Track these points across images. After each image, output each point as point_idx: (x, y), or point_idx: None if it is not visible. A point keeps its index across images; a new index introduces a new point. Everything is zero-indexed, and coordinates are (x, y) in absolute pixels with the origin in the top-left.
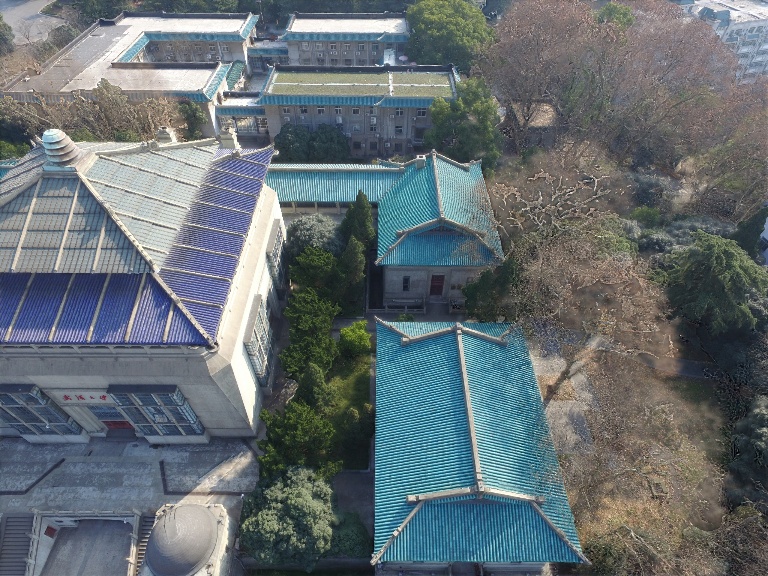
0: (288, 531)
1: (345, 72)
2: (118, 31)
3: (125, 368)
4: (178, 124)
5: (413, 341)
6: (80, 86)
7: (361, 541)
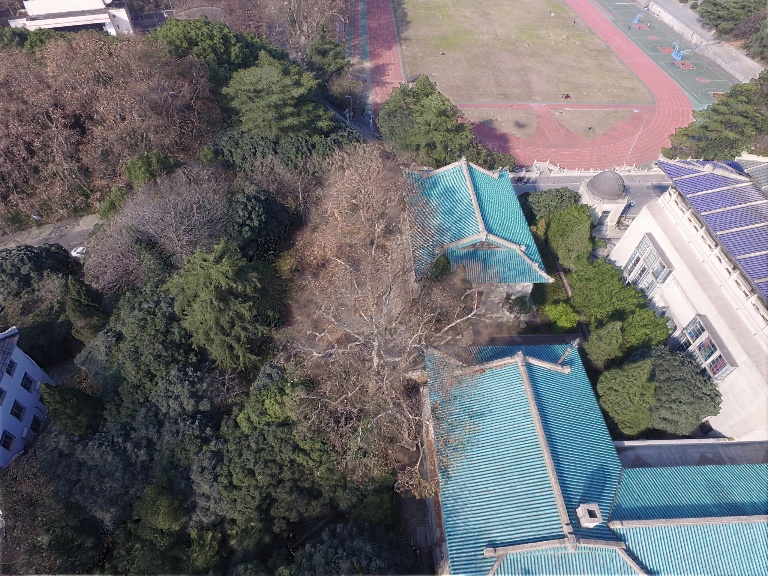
0: None
1: None
2: None
3: None
4: None
5: None
6: None
7: None
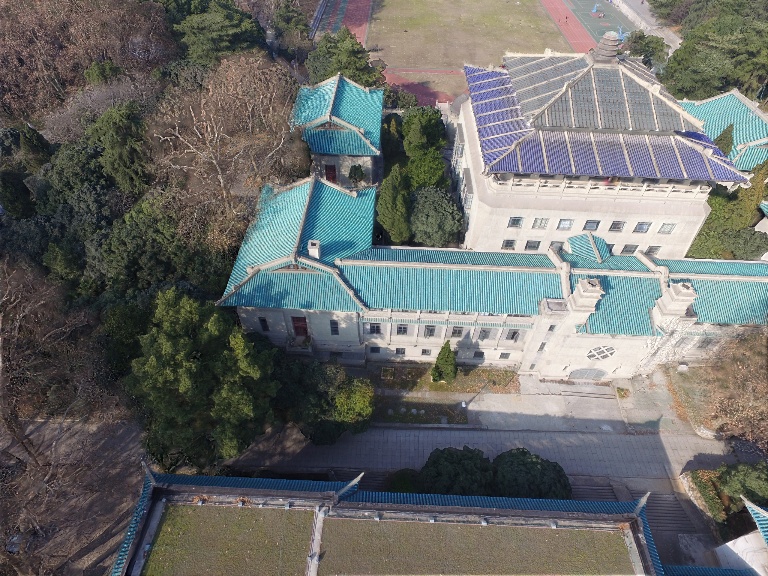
0: None
1: None
2: None
3: None
4: None
5: None
6: None
7: None
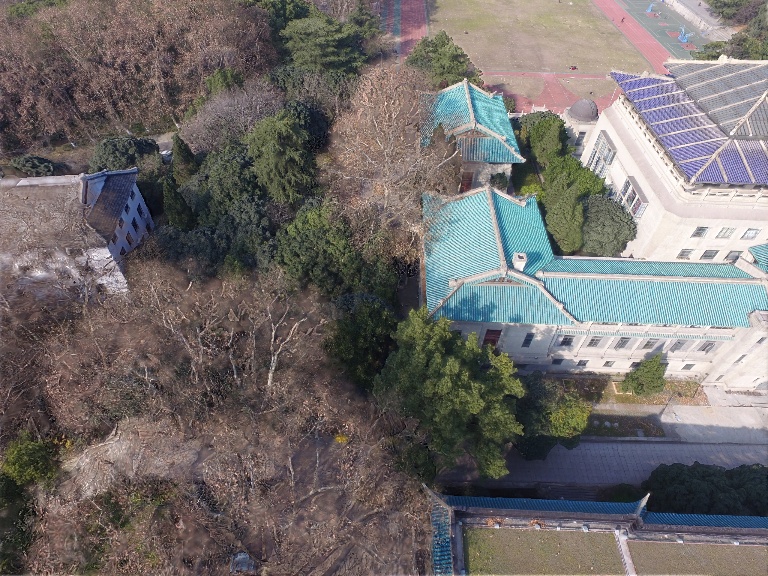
0: None
1: None
2: None
3: None
4: None
5: None
6: None
7: None
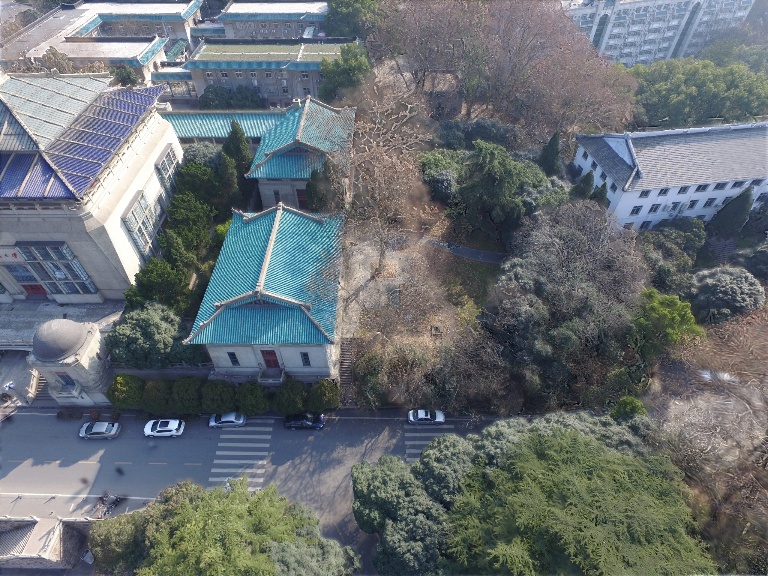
0: (136, 335)
1: (265, 44)
2: (76, 14)
3: (26, 226)
4: None
5: (251, 219)
6: (35, 55)
7: (193, 347)
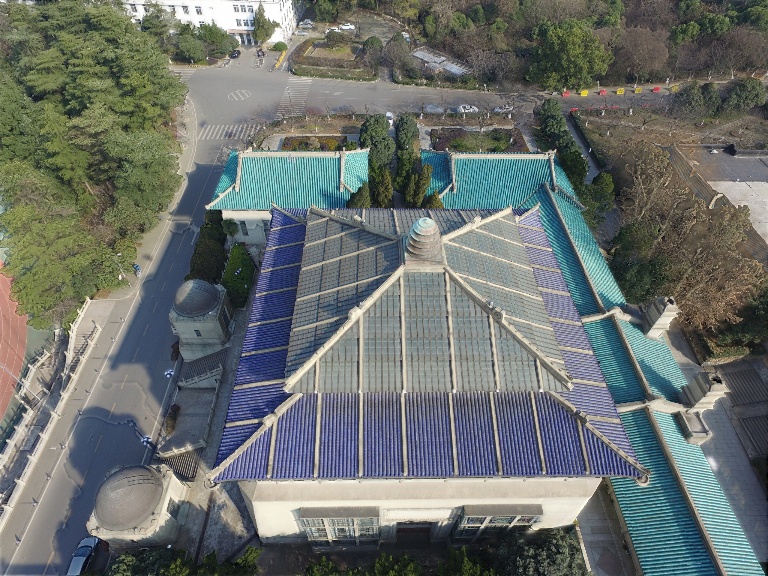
0: None
1: None
2: None
3: None
4: (743, 309)
5: None
6: (736, 192)
7: None
